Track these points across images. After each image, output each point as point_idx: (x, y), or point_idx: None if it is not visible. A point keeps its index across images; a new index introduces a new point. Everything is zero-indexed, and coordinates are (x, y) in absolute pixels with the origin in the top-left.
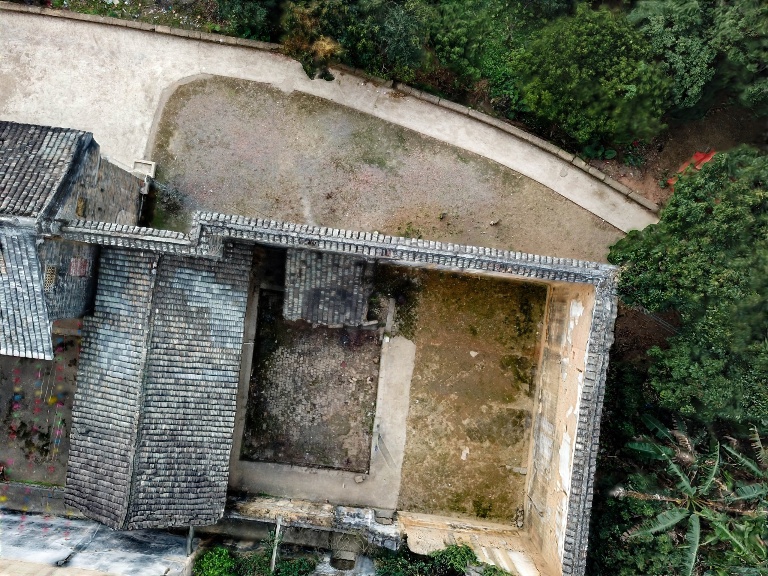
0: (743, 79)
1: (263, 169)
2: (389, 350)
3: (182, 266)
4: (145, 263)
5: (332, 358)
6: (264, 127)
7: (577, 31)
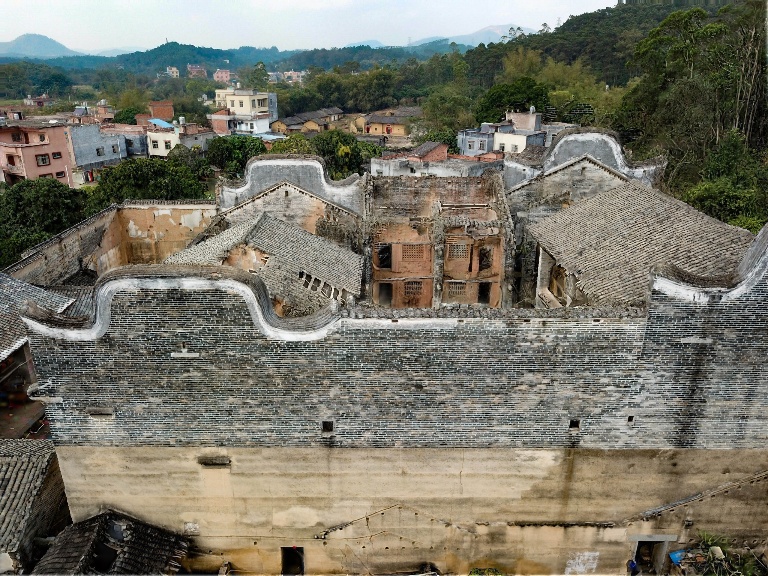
0: (59, 229)
1: None
2: None
3: None
4: None
5: None
6: None
7: (8, 244)
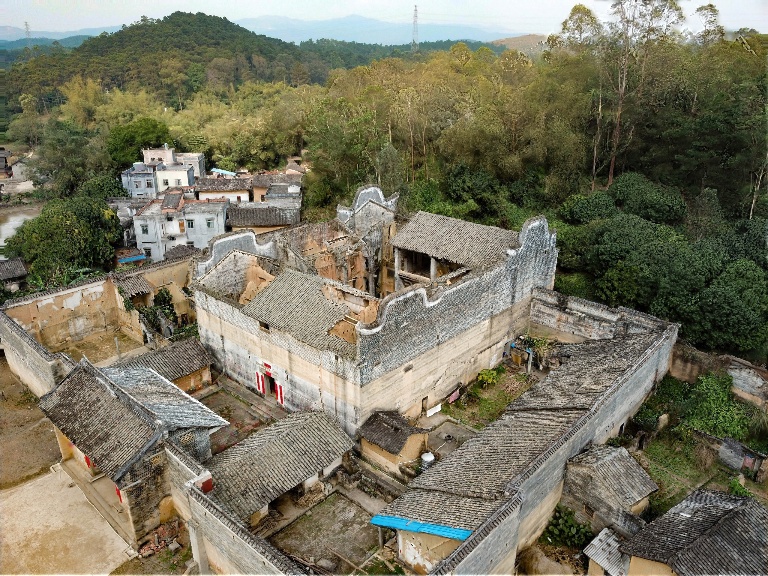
0: None
1: None
2: None
3: None
4: None
5: None
6: None
7: None
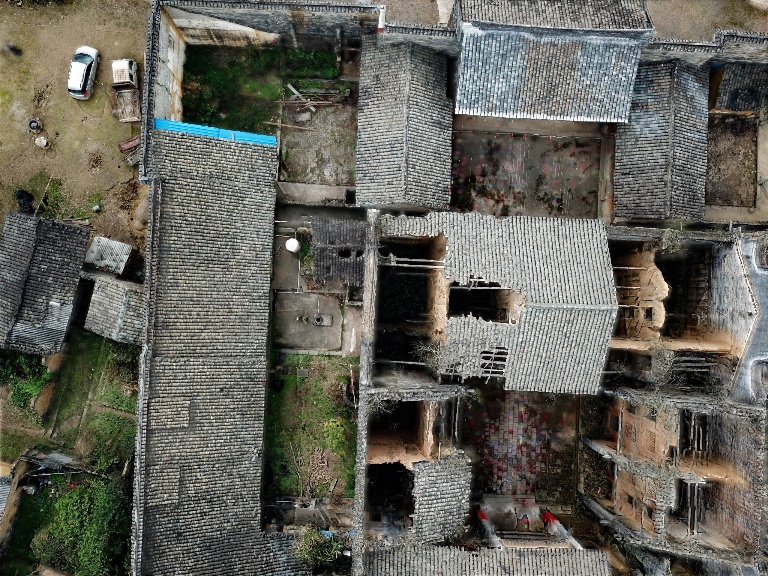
0: None
1: (672, 32)
2: (763, 132)
3: (684, 71)
4: (666, 70)
5: (728, 140)
6: (670, 7)
7: None
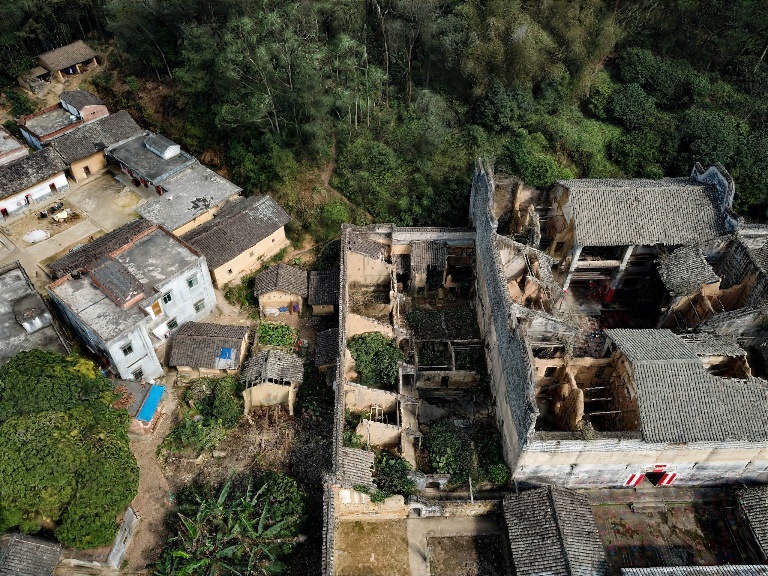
0: None
1: None
2: None
3: None
4: None
5: None
6: None
7: None
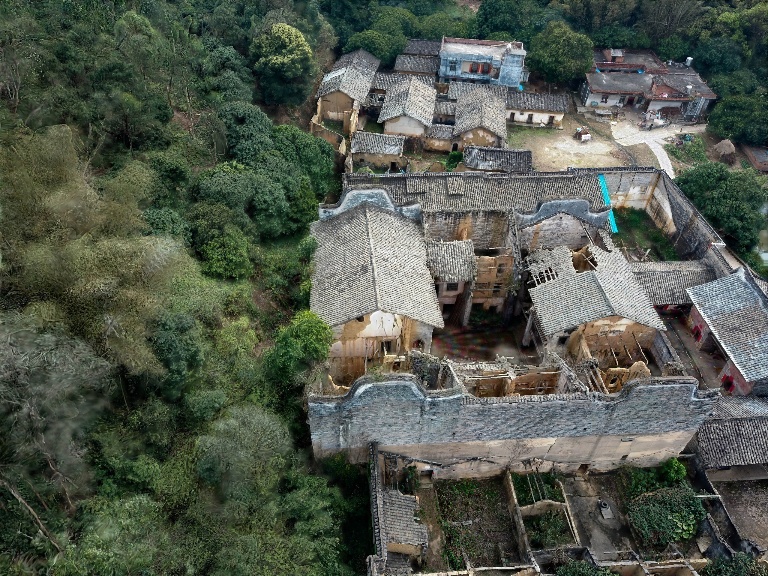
0: None
1: None
2: None
3: None
4: None
5: None
6: None
7: None
